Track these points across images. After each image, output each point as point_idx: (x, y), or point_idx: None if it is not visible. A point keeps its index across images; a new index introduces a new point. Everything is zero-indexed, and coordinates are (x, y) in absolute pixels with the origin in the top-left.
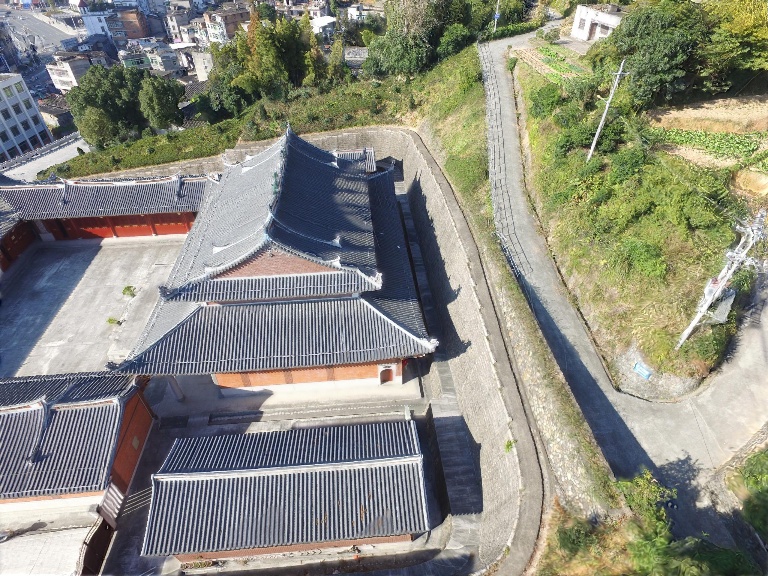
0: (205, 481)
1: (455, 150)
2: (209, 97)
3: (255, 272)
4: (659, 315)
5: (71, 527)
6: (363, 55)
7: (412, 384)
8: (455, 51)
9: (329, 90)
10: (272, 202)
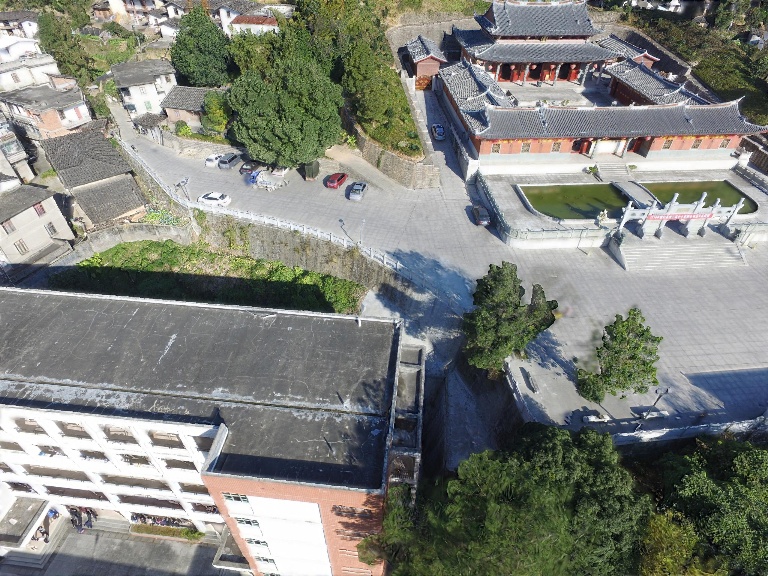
0: None
1: (461, 7)
2: None
3: None
4: None
5: None
6: (280, 11)
7: None
8: None
9: None
10: (566, 0)
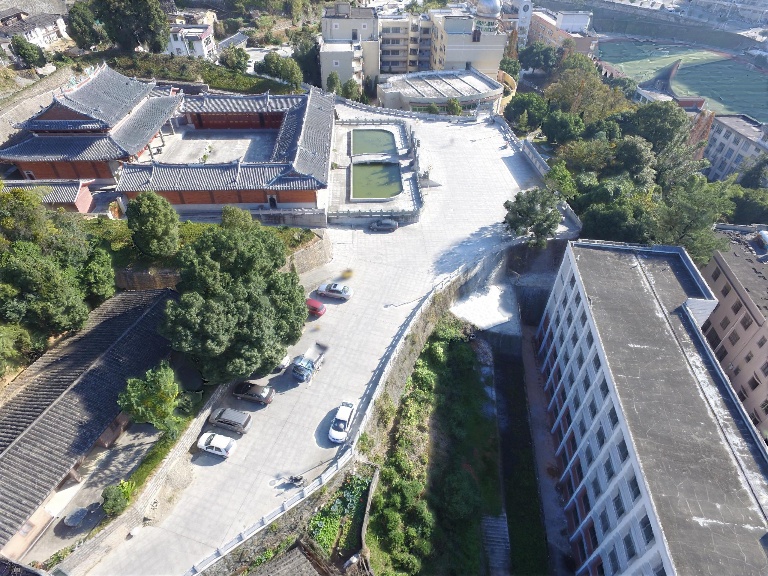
0: None
1: None
2: None
3: None
4: (1, 70)
5: None
6: None
7: None
8: None
9: None
10: None
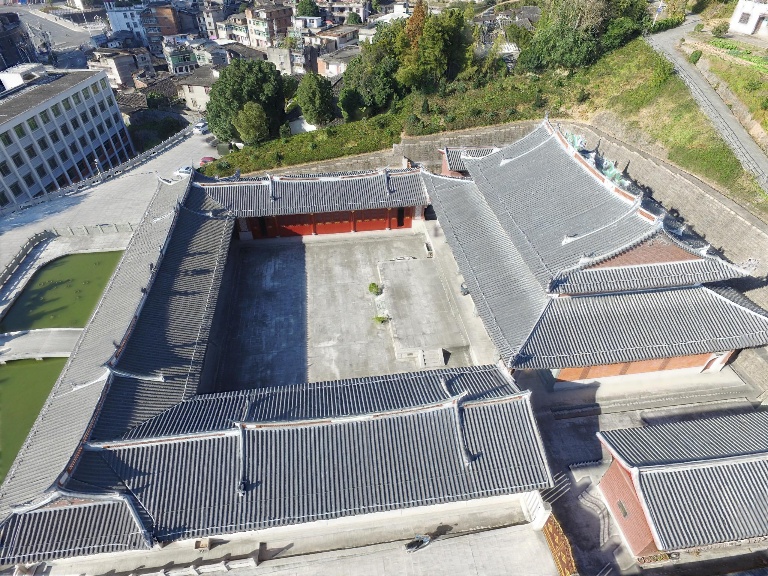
0: (682, 472)
1: (678, 141)
2: (357, 91)
3: (625, 262)
4: None
5: (482, 528)
6: None
7: (728, 371)
8: (620, 45)
9: (485, 84)
10: (627, 191)
